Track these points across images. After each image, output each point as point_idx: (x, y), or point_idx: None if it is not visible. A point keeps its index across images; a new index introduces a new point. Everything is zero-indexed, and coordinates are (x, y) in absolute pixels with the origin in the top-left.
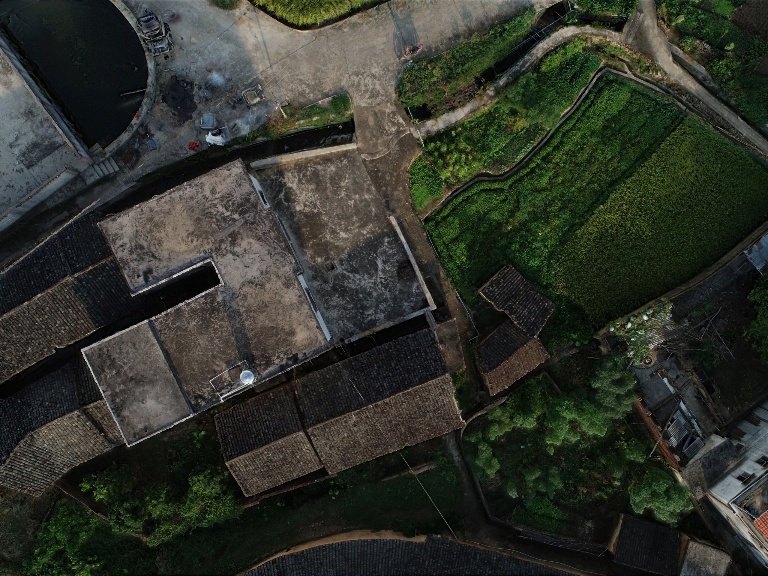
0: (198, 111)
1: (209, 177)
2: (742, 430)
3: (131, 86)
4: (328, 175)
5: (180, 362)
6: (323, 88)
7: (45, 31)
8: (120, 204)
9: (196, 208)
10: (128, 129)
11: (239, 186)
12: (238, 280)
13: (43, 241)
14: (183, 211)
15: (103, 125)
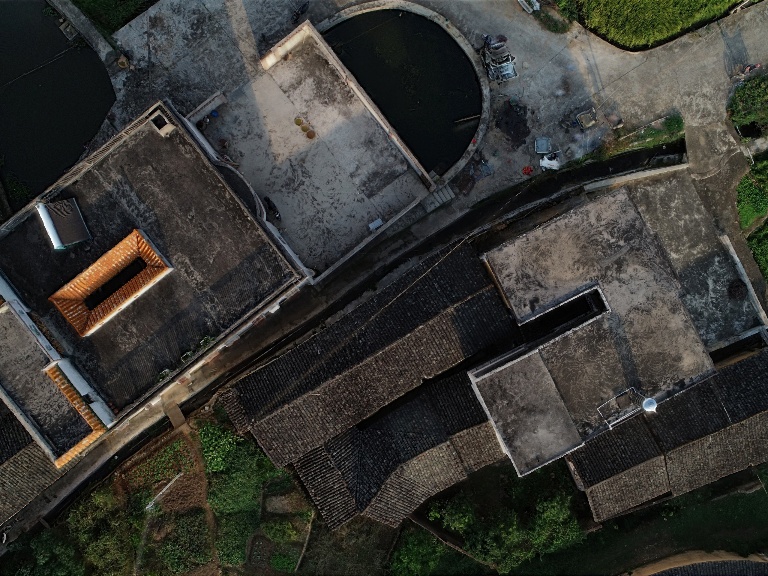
0: (531, 136)
1: (594, 204)
2: None
3: (465, 112)
4: (658, 196)
5: (567, 390)
6: (655, 109)
7: (369, 59)
8: (448, 230)
9: (581, 236)
10: (465, 156)
11: (624, 212)
12: (624, 307)
13: (425, 273)
14: (569, 239)
15: (433, 152)
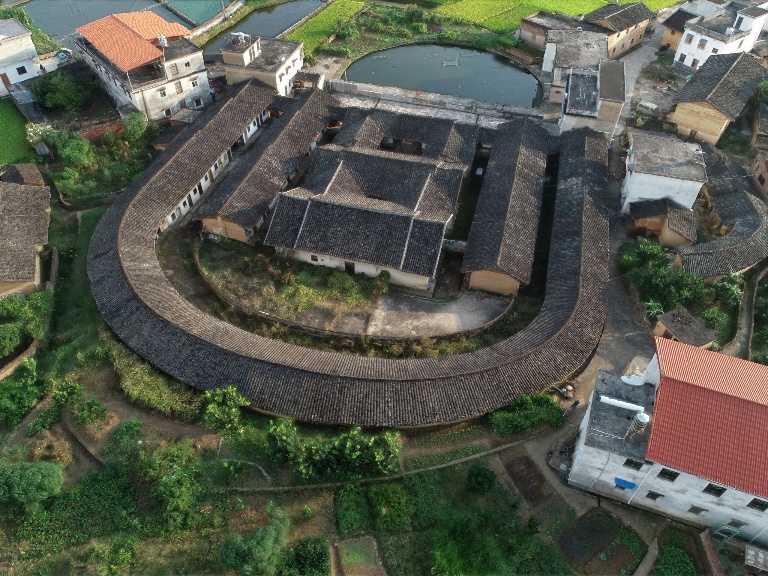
0: None
1: None
2: None
3: None
4: None
5: None
6: None
7: None
8: None
9: None
10: None
11: None
12: None
13: None
14: None
15: None
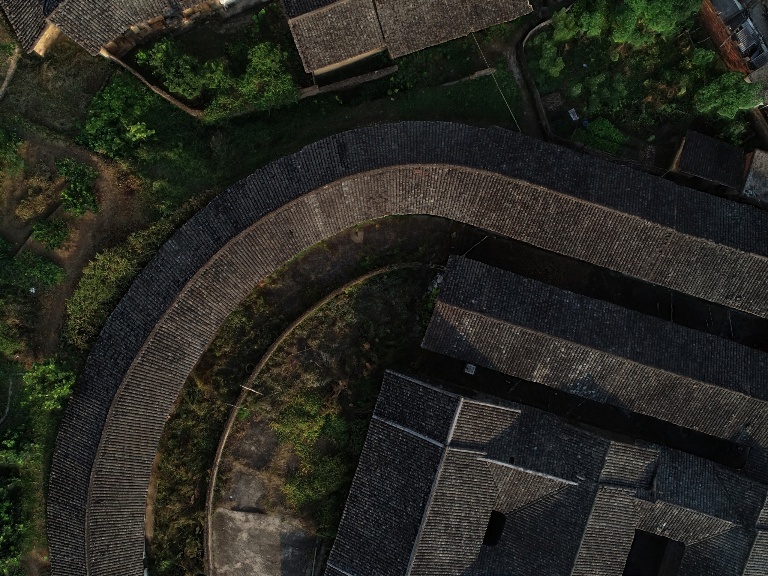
0: None
1: None
2: None
3: None
4: None
5: None
6: None
7: None
8: None
9: None
10: None
11: None
12: None
13: None
14: None
15: None
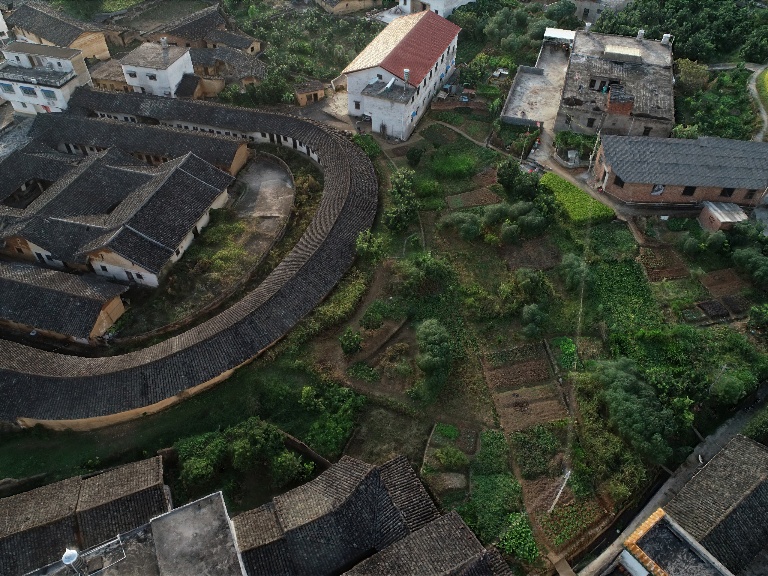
0: None
1: None
2: None
3: None
4: None
5: None
6: None
7: None
8: None
9: None
10: None
11: None
12: None
13: None
14: None
15: None
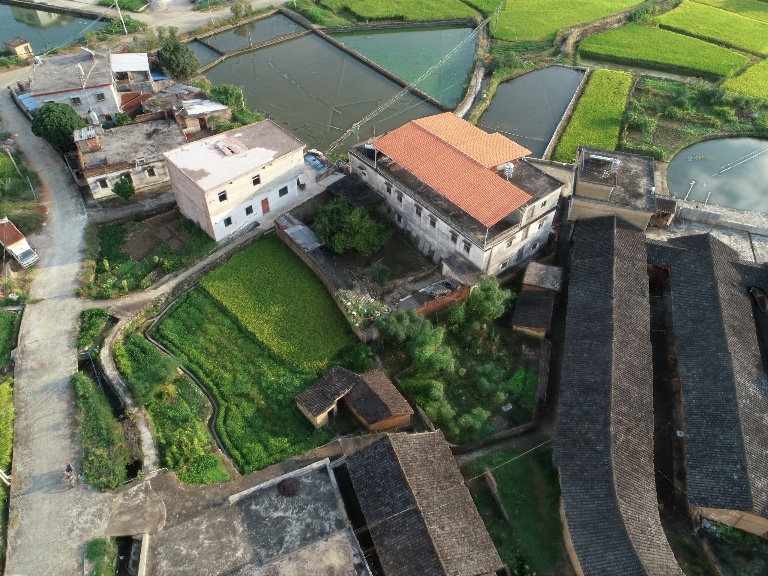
0: None
1: None
2: (439, 260)
3: None
4: (170, 569)
5: None
6: (72, 569)
7: None
8: None
9: None
10: None
11: None
12: None
13: None
14: None
15: None
